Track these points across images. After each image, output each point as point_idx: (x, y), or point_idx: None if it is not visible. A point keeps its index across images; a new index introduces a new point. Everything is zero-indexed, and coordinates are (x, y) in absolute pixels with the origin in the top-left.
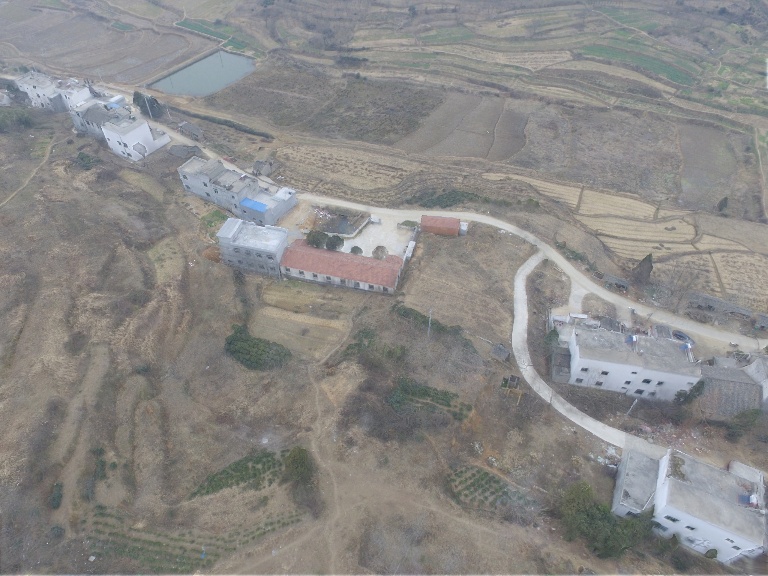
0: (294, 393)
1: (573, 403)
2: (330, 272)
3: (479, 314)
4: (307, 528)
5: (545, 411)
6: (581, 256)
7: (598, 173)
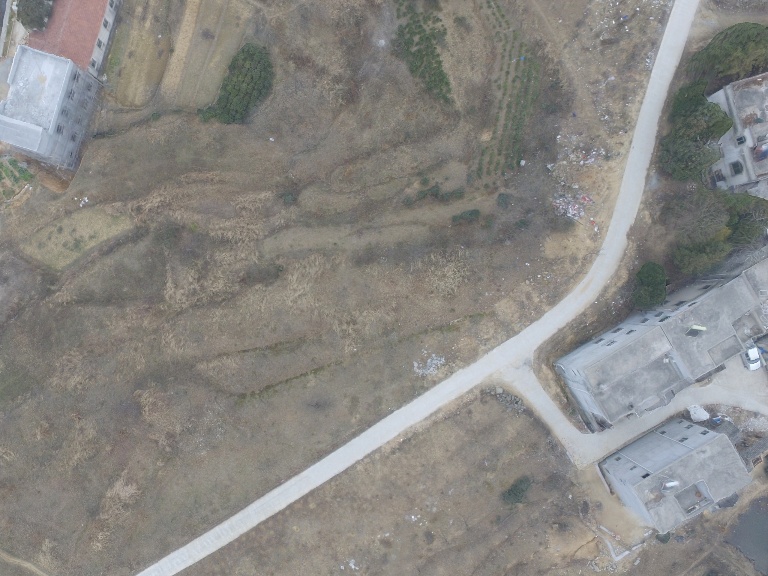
0: (313, 26)
1: None
2: None
3: None
4: None
5: None
6: None
7: None
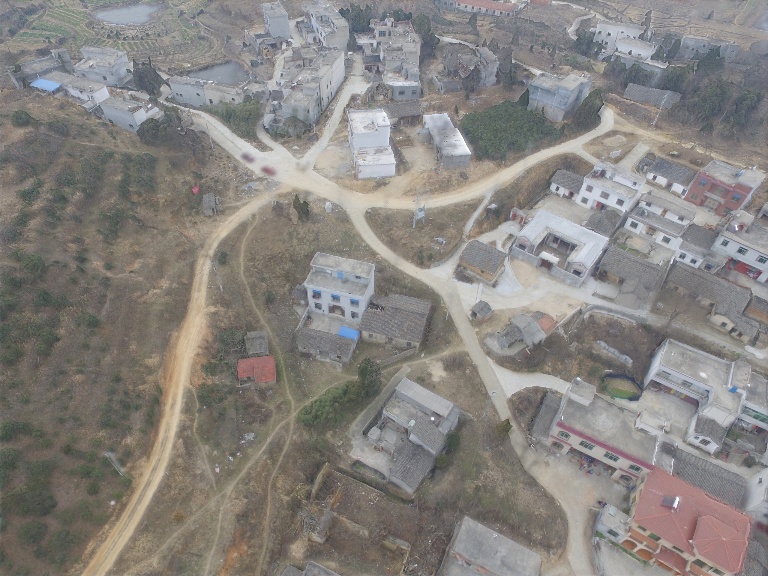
0: None
1: None
2: (481, 5)
3: (554, 23)
4: None
5: None
6: (615, 17)
7: (642, 3)
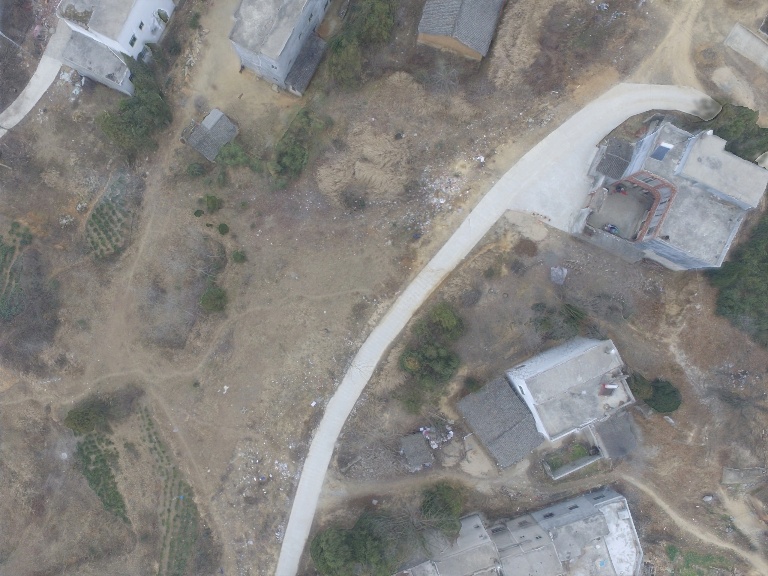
0: (3, 431)
1: (7, 103)
2: None
3: None
4: (152, 401)
5: (19, 138)
6: None
7: None
